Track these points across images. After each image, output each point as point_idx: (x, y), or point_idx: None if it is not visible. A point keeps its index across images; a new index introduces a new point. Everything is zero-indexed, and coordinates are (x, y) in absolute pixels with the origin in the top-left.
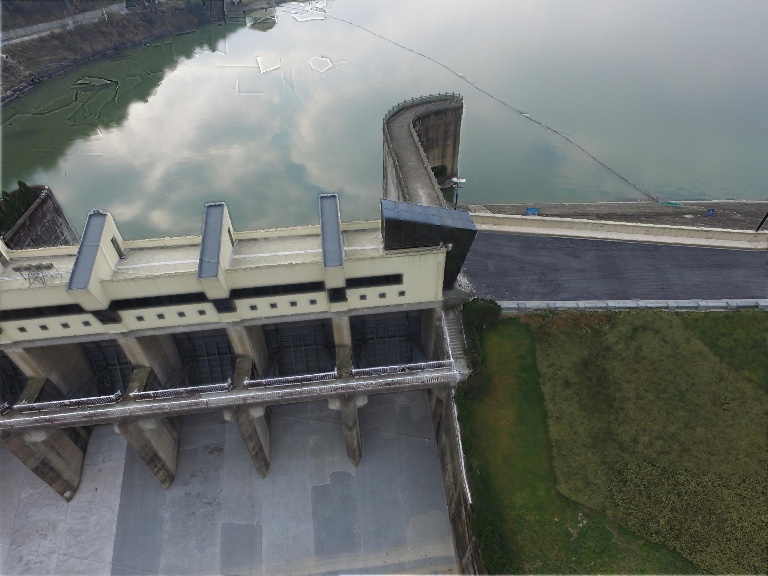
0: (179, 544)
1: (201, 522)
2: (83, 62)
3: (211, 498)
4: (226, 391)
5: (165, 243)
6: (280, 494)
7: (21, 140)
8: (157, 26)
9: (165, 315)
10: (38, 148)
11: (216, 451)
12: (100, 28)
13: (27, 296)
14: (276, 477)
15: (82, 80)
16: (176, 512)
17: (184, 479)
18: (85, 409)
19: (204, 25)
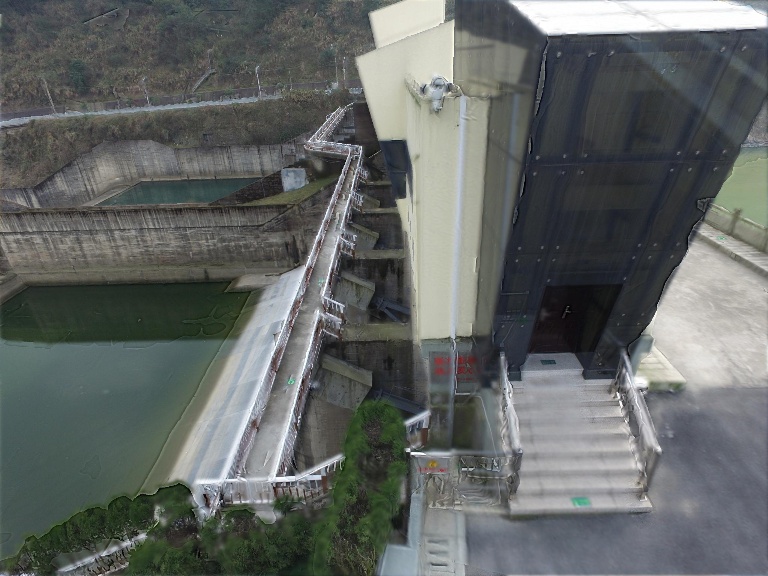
0: None
1: None
2: None
3: None
4: None
5: None
6: None
7: None
8: None
9: None
10: None
11: None
12: None
13: None
14: None
15: None
16: None
17: None
18: None
19: None
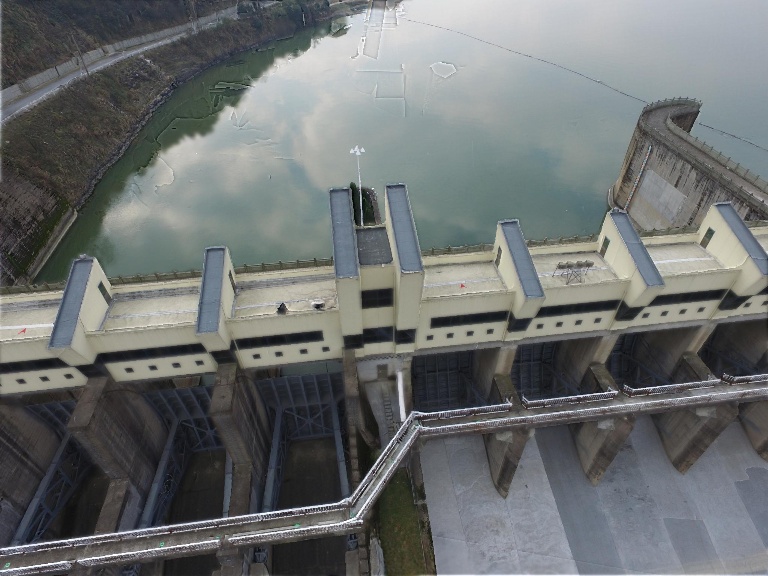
0: (630, 539)
1: (642, 518)
2: (207, 67)
3: (641, 494)
4: (712, 387)
5: (651, 242)
6: (707, 490)
7: (199, 144)
8: (264, 32)
9: (669, 312)
10: (222, 151)
11: (626, 448)
12: (219, 34)
13: (576, 293)
14: (695, 473)
15: (218, 85)
16: (614, 508)
17: (607, 475)
18: (586, 405)
19: (299, 31)
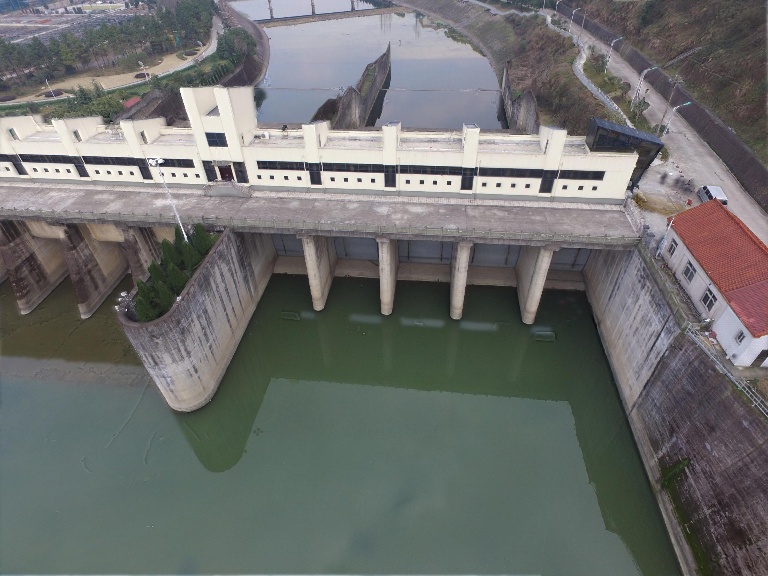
0: None
1: None
2: None
3: None
4: None
5: None
6: None
7: None
8: None
9: None
10: None
11: None
12: None
13: None
14: None
15: None
16: None
17: None
18: None
19: None
